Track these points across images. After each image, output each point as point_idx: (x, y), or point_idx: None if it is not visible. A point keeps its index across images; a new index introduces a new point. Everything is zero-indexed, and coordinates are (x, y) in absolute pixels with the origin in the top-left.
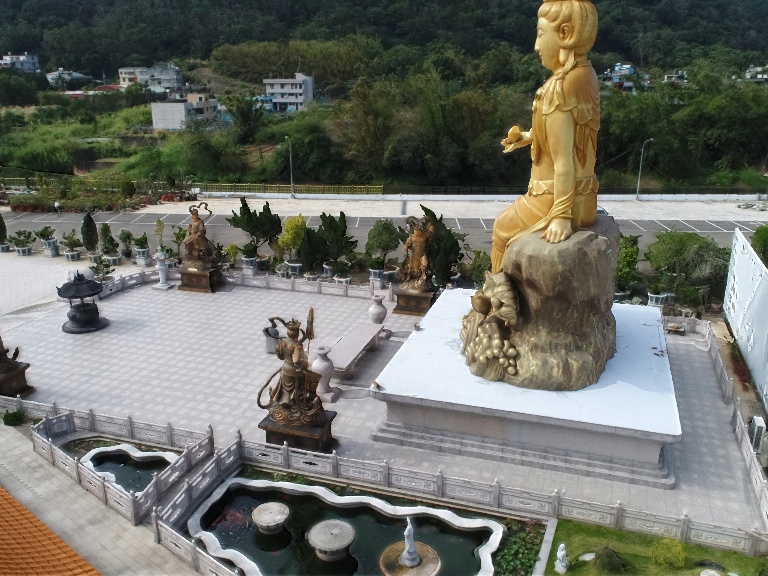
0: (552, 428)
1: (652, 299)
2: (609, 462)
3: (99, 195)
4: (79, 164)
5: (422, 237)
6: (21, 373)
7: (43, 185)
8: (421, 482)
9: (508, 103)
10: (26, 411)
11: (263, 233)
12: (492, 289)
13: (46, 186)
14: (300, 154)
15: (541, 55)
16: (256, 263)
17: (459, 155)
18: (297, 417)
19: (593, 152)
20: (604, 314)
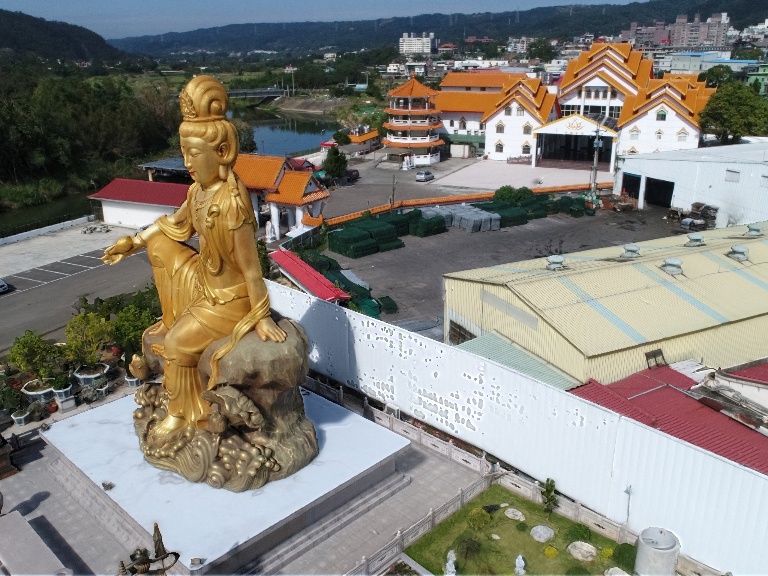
0: (337, 493)
1: None
2: (373, 491)
3: None
4: None
5: None
6: None
7: None
8: None
9: None
10: None
11: None
12: (235, 406)
13: None
14: None
15: (196, 172)
16: None
17: None
18: None
19: None
20: None
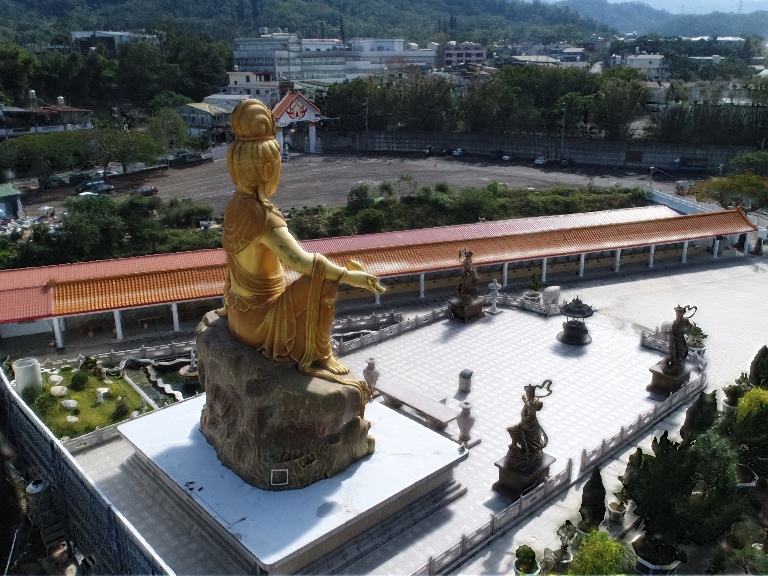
0: None
1: None
2: None
3: None
4: None
5: None
6: (462, 309)
7: None
8: None
9: None
10: None
11: None
12: None
13: None
14: None
15: None
16: None
17: None
18: None
19: None
20: None
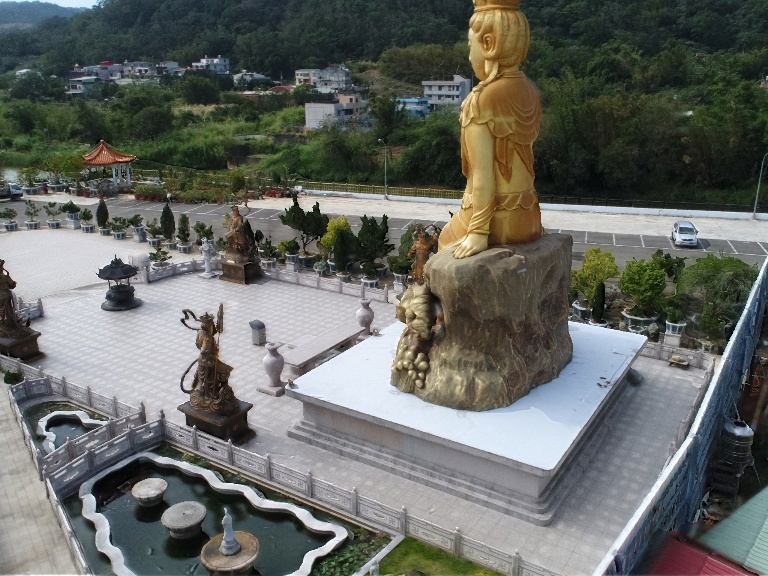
0: (439, 446)
1: (669, 327)
2: (490, 488)
3: (211, 188)
4: (231, 159)
5: (426, 244)
6: (33, 340)
7: (173, 177)
8: (295, 480)
9: (647, 108)
10: (23, 373)
11: (313, 232)
12: (409, 300)
13: (175, 178)
14: (427, 156)
15: None
16: (302, 260)
17: (588, 162)
18: (208, 404)
19: (524, 167)
20: (532, 336)
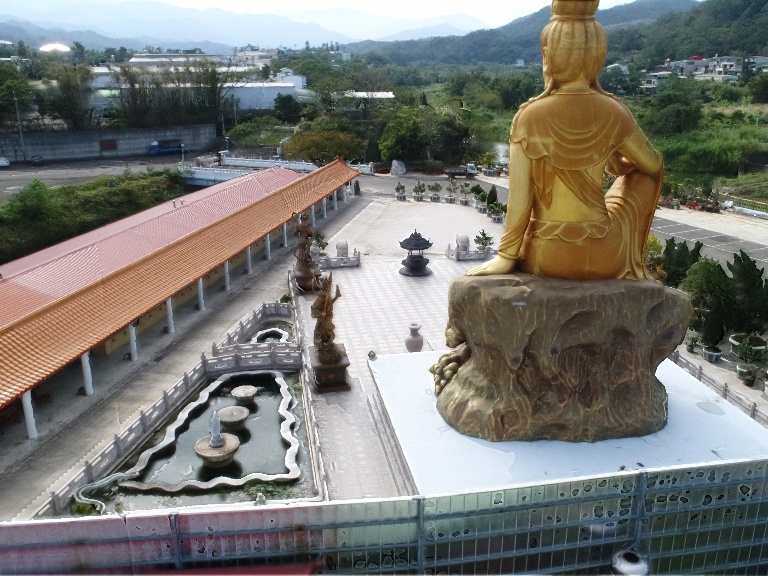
0: None
1: None
2: None
3: None
4: (741, 166)
5: None
6: None
7: None
8: None
9: None
10: None
11: None
12: None
13: None
14: None
15: None
16: None
17: None
18: None
19: (573, 195)
20: (550, 382)
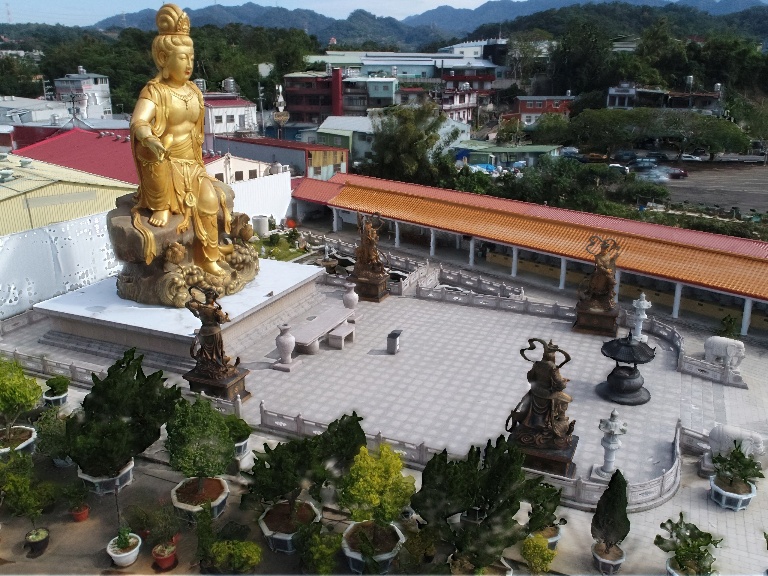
0: None
1: None
2: None
3: None
4: None
5: None
6: None
7: None
8: None
9: None
10: None
11: None
12: None
13: None
14: None
15: None
16: None
17: None
18: None
19: None
20: None
